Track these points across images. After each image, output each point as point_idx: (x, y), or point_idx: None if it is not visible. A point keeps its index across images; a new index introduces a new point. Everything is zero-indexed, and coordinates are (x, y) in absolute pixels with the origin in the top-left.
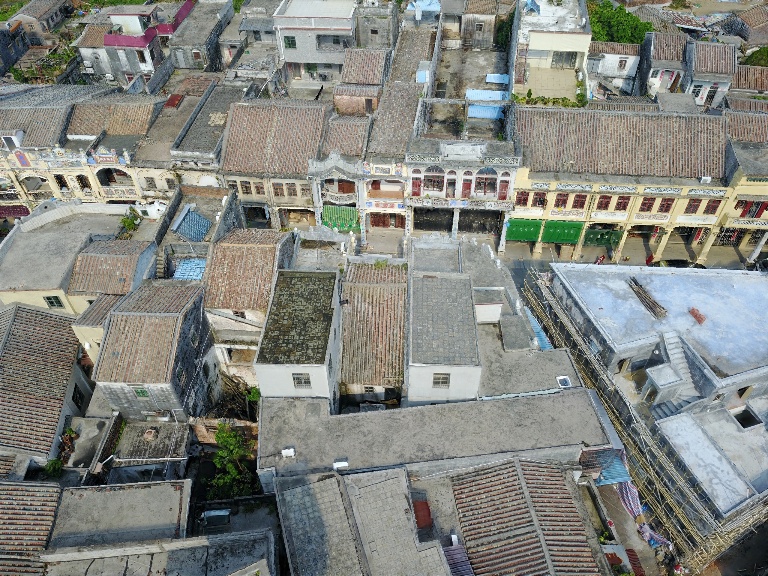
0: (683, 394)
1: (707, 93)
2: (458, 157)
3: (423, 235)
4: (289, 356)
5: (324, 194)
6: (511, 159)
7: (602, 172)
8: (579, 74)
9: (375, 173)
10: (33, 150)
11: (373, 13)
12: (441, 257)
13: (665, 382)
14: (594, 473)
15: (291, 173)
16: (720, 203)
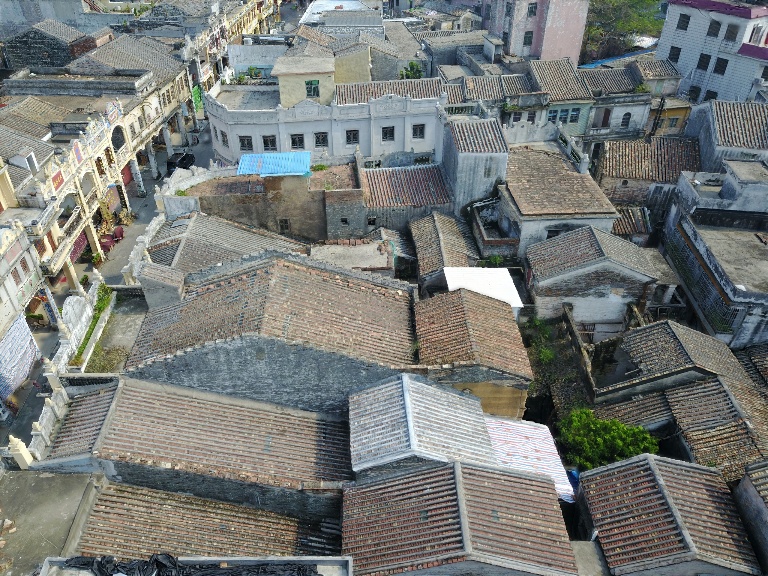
0: None
1: None
2: None
3: None
4: None
5: None
6: (227, 5)
7: None
8: (117, 6)
9: (200, 45)
10: (45, 164)
11: None
12: None
13: None
14: None
15: None
16: None
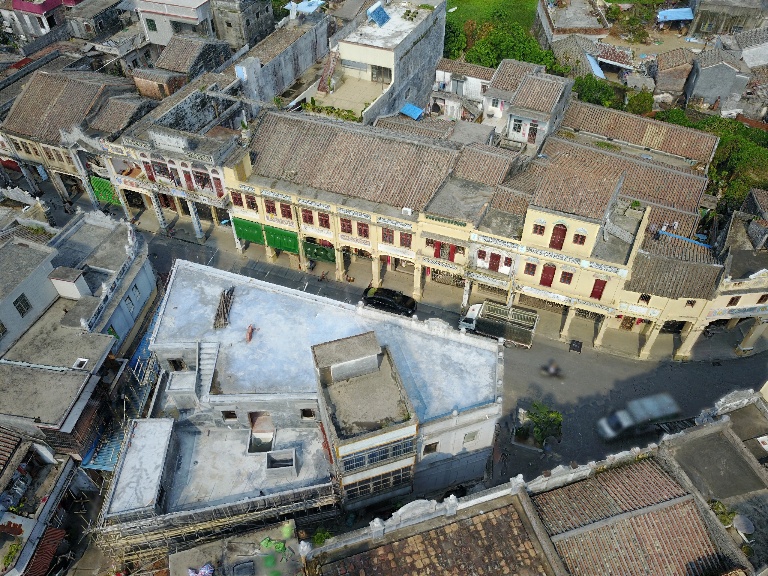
0: (203, 404)
1: (528, 130)
2: (168, 147)
3: (90, 212)
4: None
5: (91, 165)
6: (206, 156)
7: (316, 186)
8: None
9: (112, 151)
10: None
11: (224, 6)
12: (99, 235)
13: (177, 387)
14: (72, 453)
15: (52, 140)
16: (412, 237)
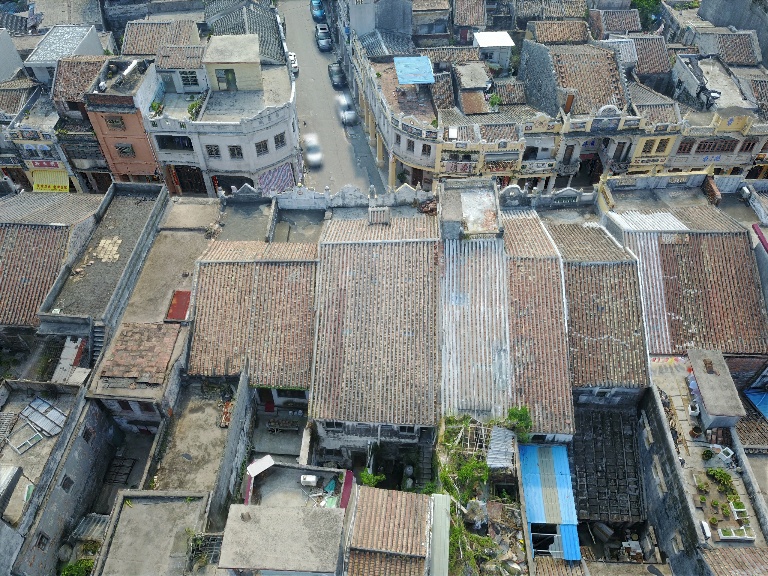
0: None
1: None
2: None
3: None
4: (73, 29)
5: None
6: None
7: None
8: None
9: None
10: None
11: None
12: None
13: None
14: None
15: None
16: None
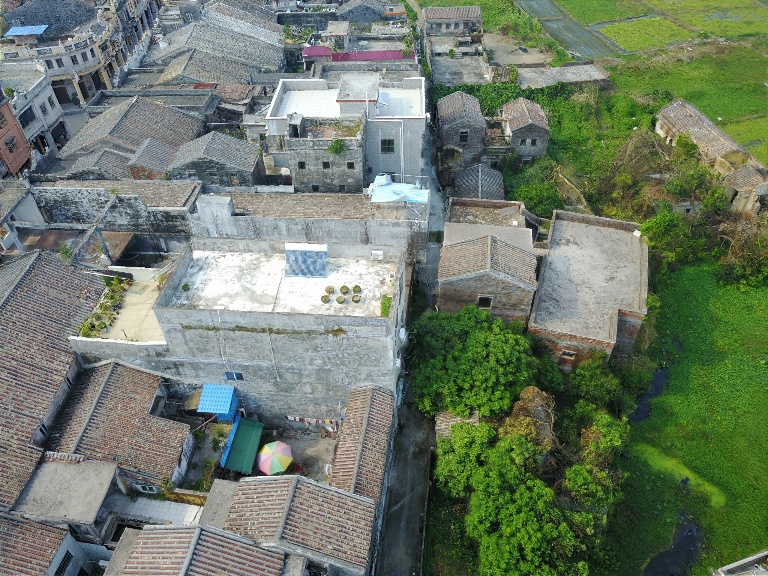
0: None
1: None
2: None
3: None
4: None
5: None
6: None
7: None
8: None
9: None
10: None
11: None
12: None
13: None
14: None
15: None
16: None
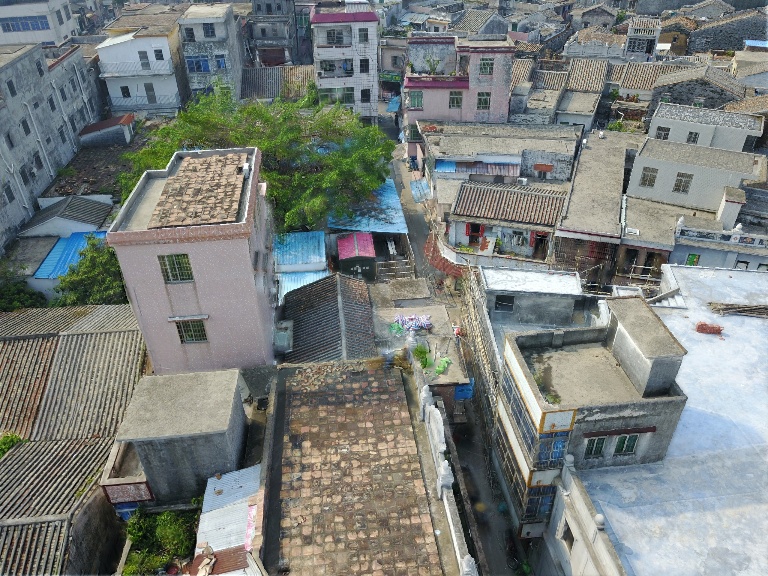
0: None
1: None
2: None
3: None
4: (666, 111)
5: None
6: None
7: None
8: None
9: None
10: None
11: None
12: None
13: (621, 294)
14: None
15: None
16: None
